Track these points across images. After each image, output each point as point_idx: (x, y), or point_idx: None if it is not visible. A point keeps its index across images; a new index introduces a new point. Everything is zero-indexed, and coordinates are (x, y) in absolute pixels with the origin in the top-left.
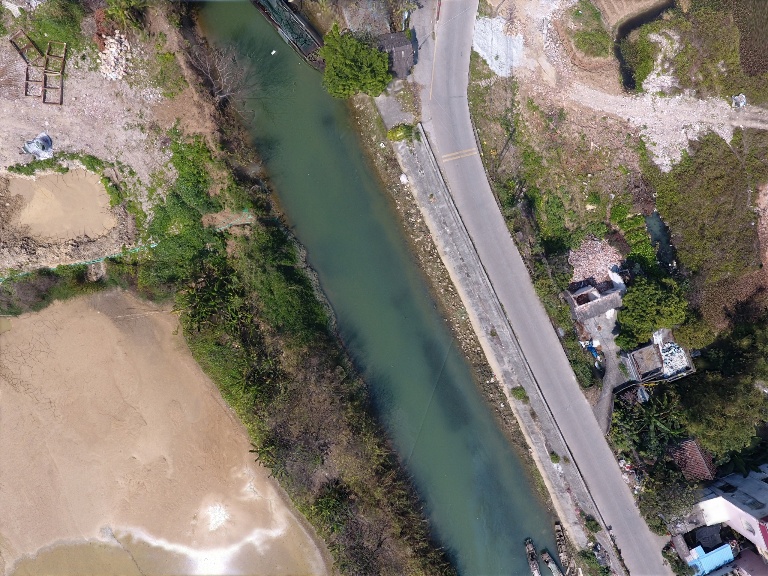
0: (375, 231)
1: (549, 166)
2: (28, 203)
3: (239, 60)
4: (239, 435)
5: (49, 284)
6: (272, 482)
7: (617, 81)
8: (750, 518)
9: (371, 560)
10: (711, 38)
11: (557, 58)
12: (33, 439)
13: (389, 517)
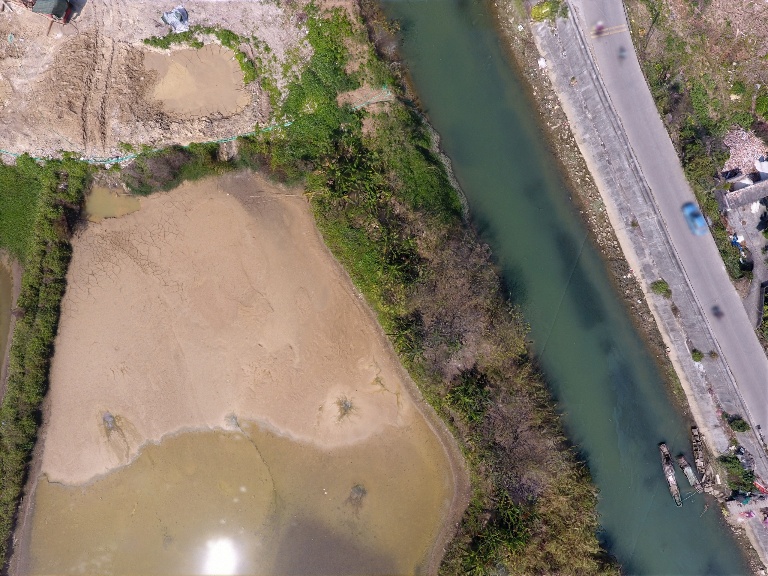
0: (509, 119)
1: (693, 53)
2: (162, 78)
3: None
4: (367, 326)
5: (183, 160)
6: (399, 375)
7: None
8: None
9: (504, 456)
10: None
11: None
12: (160, 322)
13: (527, 408)
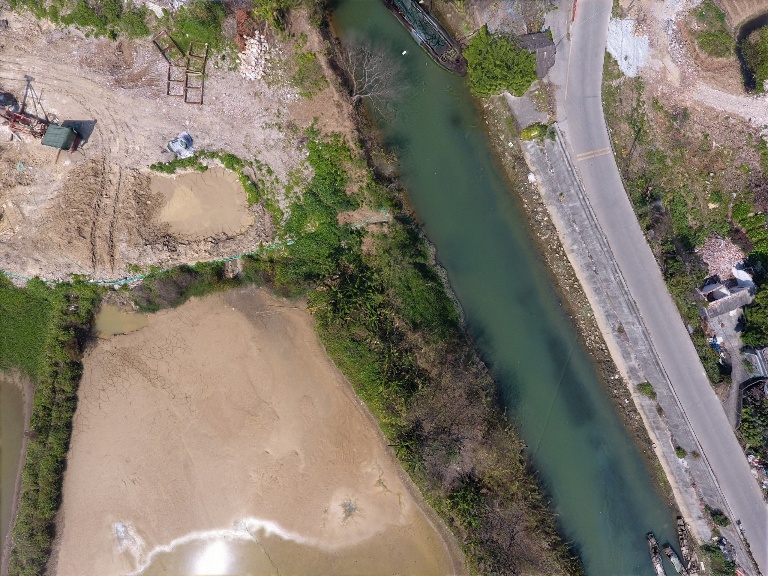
0: (501, 229)
1: (673, 165)
2: (168, 201)
3: None
4: (369, 430)
5: (190, 281)
6: (401, 477)
7: (739, 81)
8: None
9: (502, 554)
10: None
11: (681, 59)
12: (169, 434)
13: (523, 511)
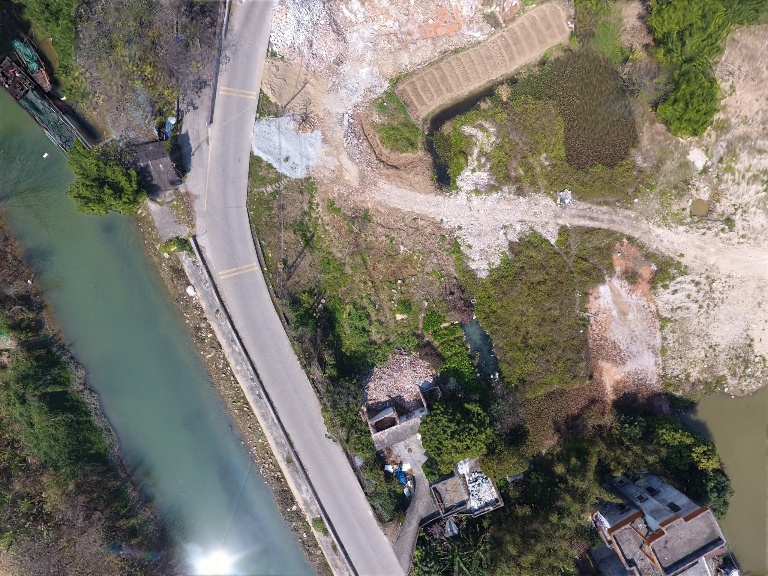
0: (165, 346)
1: (353, 273)
2: None
3: (8, 164)
4: None
5: None
6: None
7: (428, 178)
8: None
9: None
10: (529, 131)
11: (360, 155)
12: None
13: None
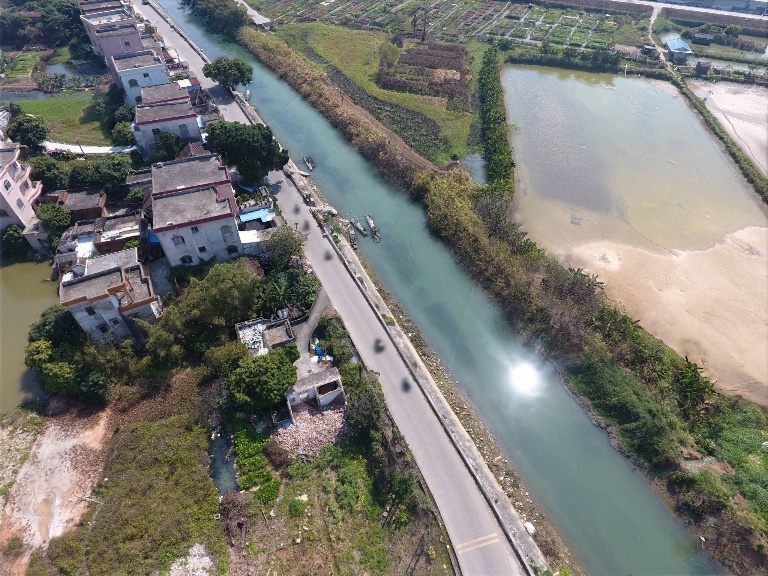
0: (545, 470)
1: (351, 551)
2: None
3: None
4: None
5: None
6: None
7: None
8: None
9: None
10: None
11: None
12: (763, 302)
13: None
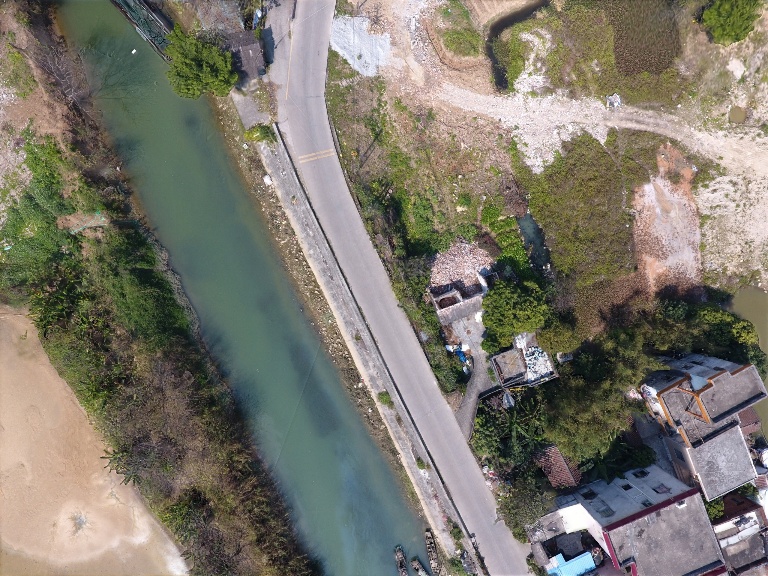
0: (241, 233)
1: (418, 167)
2: None
3: (99, 59)
4: (100, 441)
5: None
6: (134, 489)
7: (488, 81)
8: (598, 526)
9: (231, 568)
10: (583, 37)
11: (425, 57)
12: None
13: (246, 524)
